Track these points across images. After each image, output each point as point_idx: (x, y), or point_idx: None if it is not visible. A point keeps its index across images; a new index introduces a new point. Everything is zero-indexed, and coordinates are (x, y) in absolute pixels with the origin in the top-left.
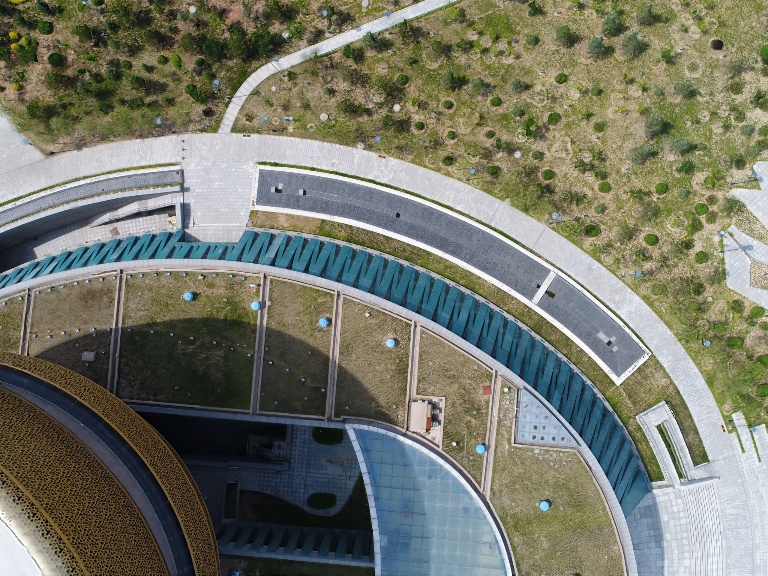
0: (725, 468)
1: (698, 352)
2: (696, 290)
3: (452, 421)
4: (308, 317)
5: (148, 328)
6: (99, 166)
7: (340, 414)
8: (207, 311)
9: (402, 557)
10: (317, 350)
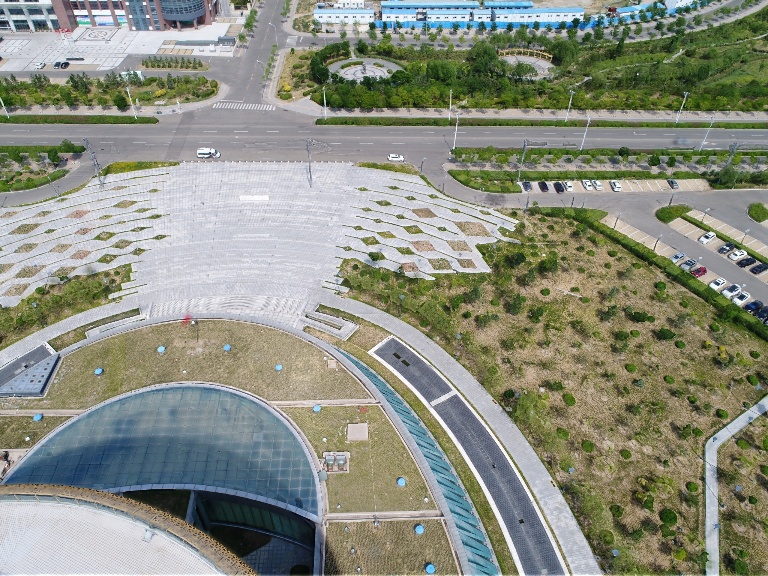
0: (146, 300)
1: (56, 318)
2: (8, 321)
3: (7, 443)
4: None
5: None
6: None
7: None
8: None
9: (118, 470)
10: None
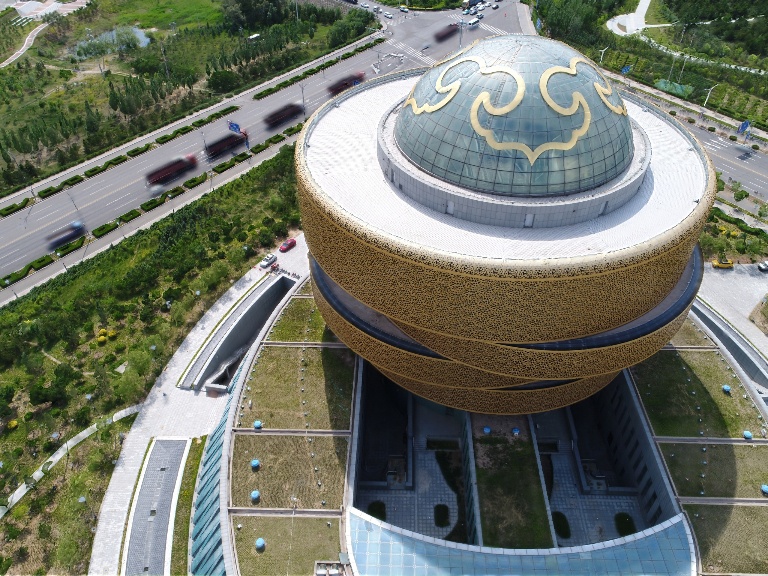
0: None
1: None
2: None
3: None
4: (761, 478)
5: (685, 366)
6: (762, 347)
7: (687, 509)
8: (721, 402)
9: (574, 575)
10: (735, 487)
